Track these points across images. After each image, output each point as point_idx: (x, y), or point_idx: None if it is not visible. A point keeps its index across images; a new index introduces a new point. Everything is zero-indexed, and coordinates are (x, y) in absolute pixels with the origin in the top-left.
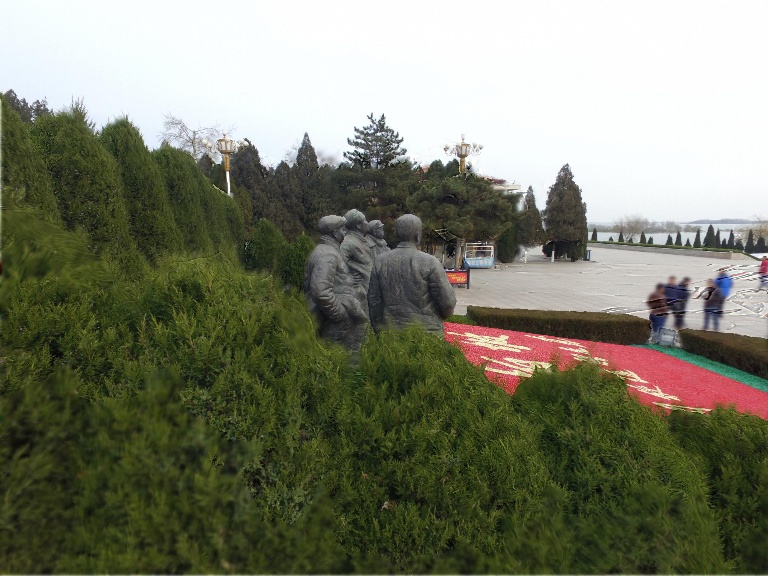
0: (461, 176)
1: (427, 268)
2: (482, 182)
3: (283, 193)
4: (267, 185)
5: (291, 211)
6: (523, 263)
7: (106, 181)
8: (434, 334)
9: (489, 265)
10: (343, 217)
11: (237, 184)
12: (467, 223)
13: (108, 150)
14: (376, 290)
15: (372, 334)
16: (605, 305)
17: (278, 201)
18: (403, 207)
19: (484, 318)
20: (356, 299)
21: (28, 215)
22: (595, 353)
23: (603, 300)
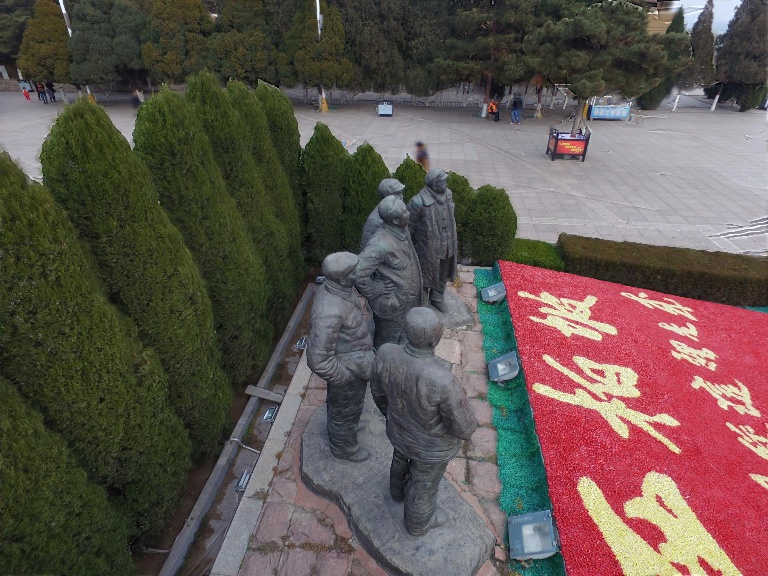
0: (605, 5)
1: (437, 396)
2: (633, 15)
3: (380, 13)
4: (362, 2)
5: (388, 37)
6: (670, 111)
7: (38, 248)
8: (443, 455)
9: (622, 116)
10: (354, 256)
11: (328, 0)
12: (597, 80)
13: (64, 155)
14: (378, 385)
15: None
16: (759, 211)
17: (374, 24)
18: (524, 35)
19: (575, 260)
20: (368, 355)
21: None
22: (706, 336)
23: (759, 199)
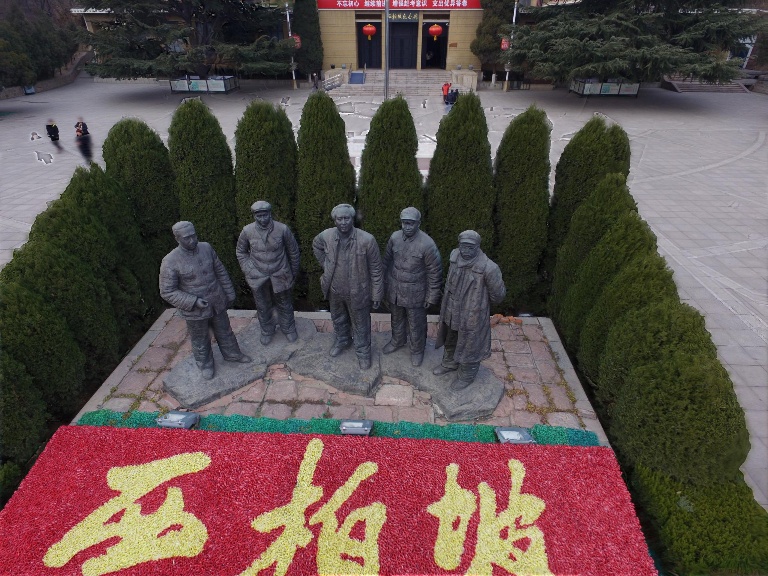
0: None
1: None
2: None
3: None
4: None
5: None
6: None
7: None
8: None
9: None
10: (258, 206)
11: None
12: None
13: None
14: None
15: (43, 240)
16: None
17: None
18: None
19: None
20: (254, 270)
21: (75, 178)
22: None
23: None
